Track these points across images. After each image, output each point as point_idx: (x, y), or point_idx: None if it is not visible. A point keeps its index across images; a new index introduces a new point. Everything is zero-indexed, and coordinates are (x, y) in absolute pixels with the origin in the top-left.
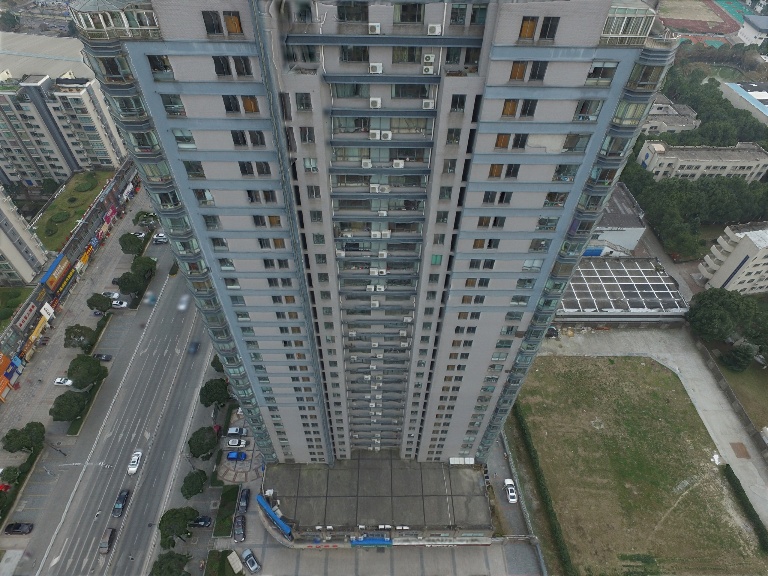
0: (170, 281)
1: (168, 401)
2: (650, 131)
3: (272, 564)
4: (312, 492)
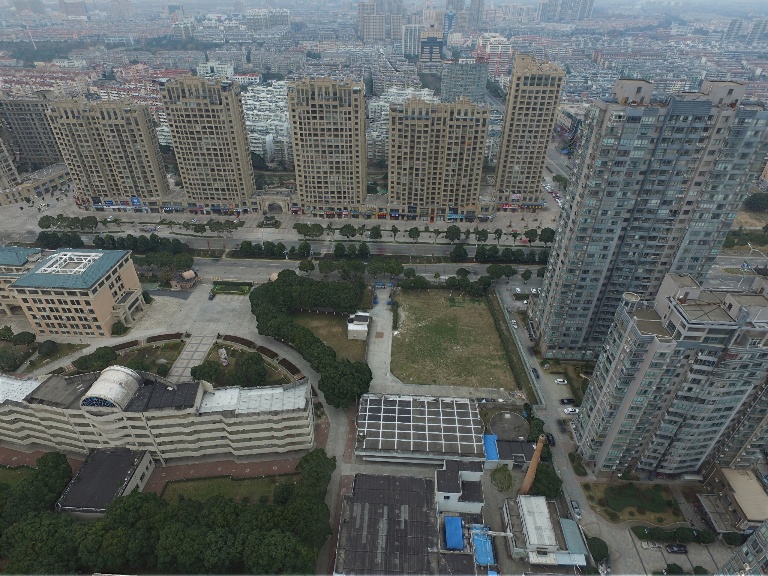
0: None
1: None
2: None
3: None
4: None
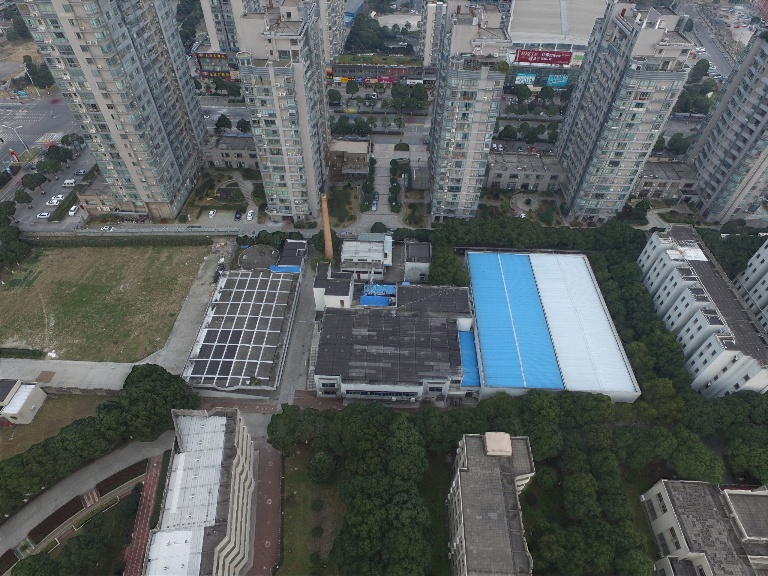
0: None
1: (236, 121)
2: (694, 573)
3: None
4: None
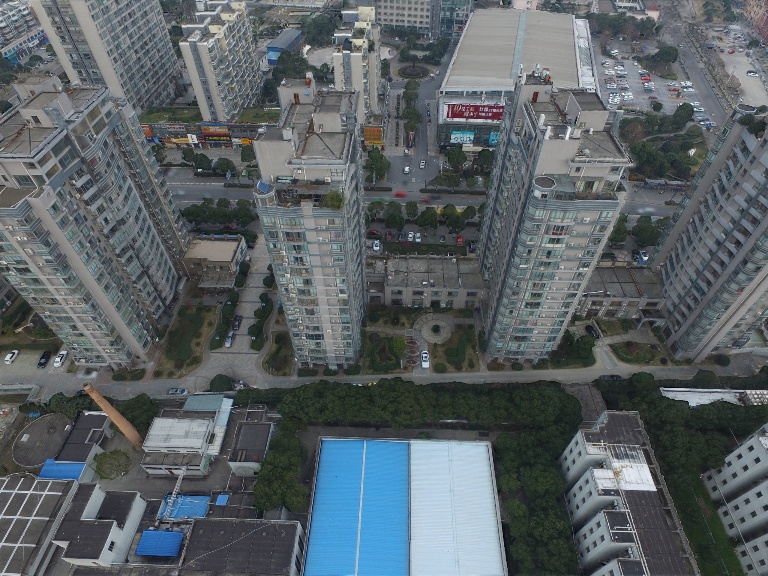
0: (218, 186)
1: None
2: None
3: None
4: None
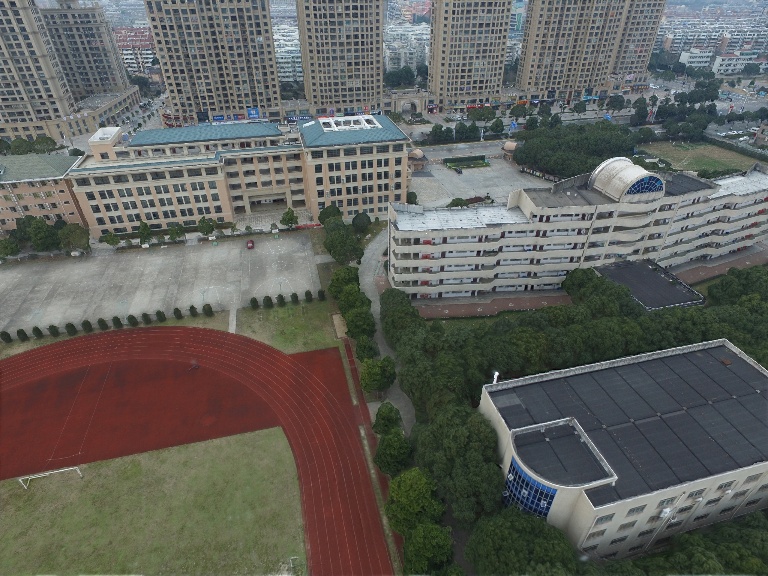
0: None
1: None
2: None
3: None
4: None
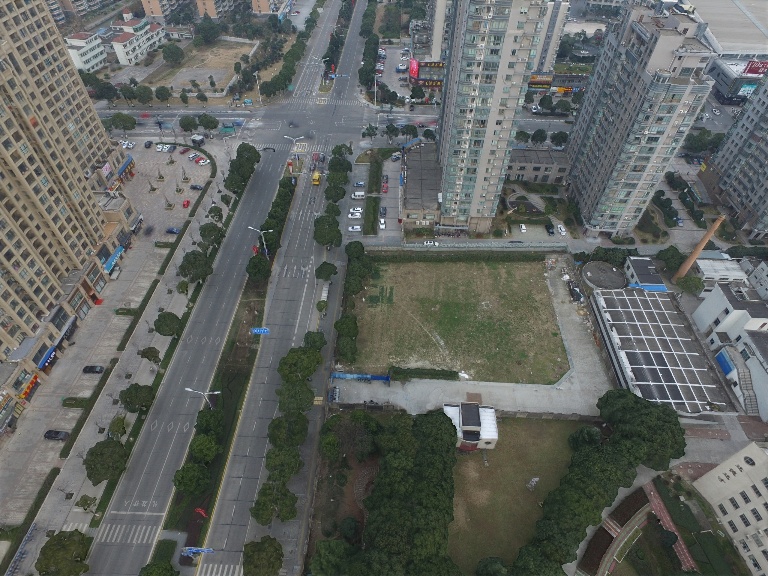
0: (560, 123)
1: None
2: None
3: (395, 164)
4: (423, 156)
